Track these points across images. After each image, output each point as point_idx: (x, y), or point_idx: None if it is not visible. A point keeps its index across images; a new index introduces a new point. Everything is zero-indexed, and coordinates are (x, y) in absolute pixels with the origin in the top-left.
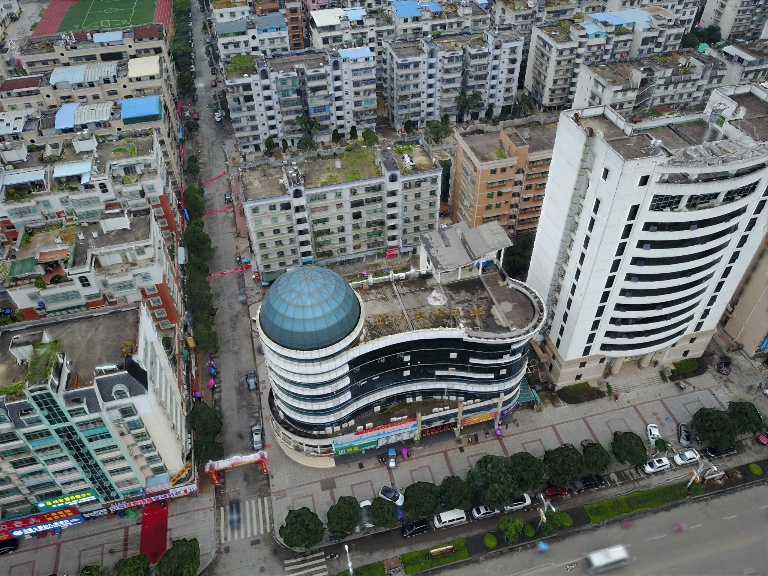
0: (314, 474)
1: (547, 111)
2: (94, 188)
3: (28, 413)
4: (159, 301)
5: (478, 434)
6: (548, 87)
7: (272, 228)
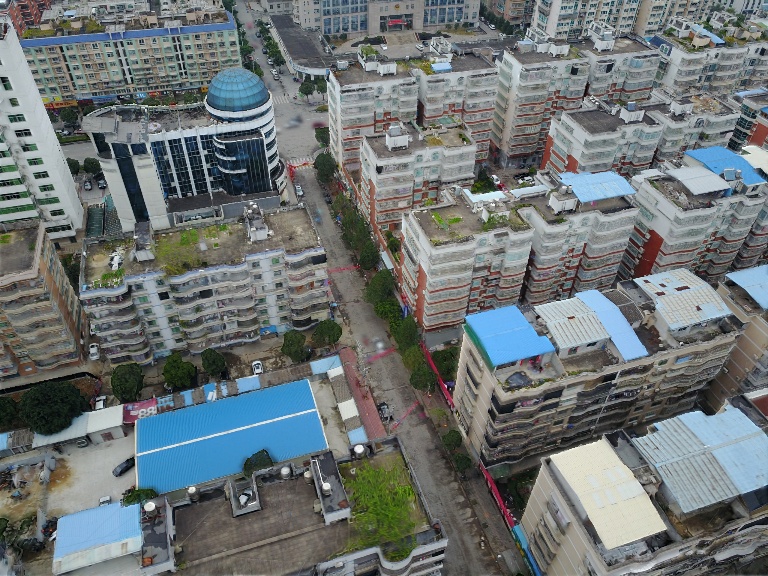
0: None
1: None
2: None
3: None
4: None
5: None
6: None
7: None
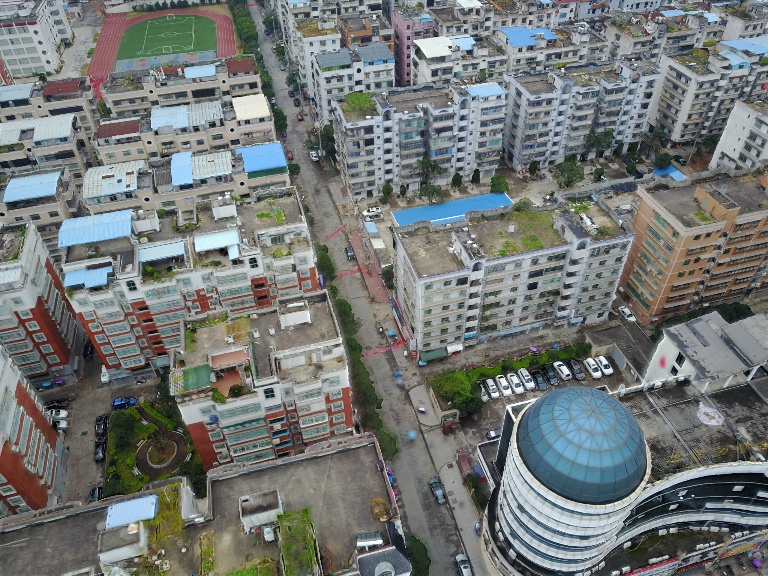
0: None
1: (675, 147)
2: (243, 263)
3: None
4: (341, 406)
5: (732, 566)
6: (681, 122)
7: (442, 305)
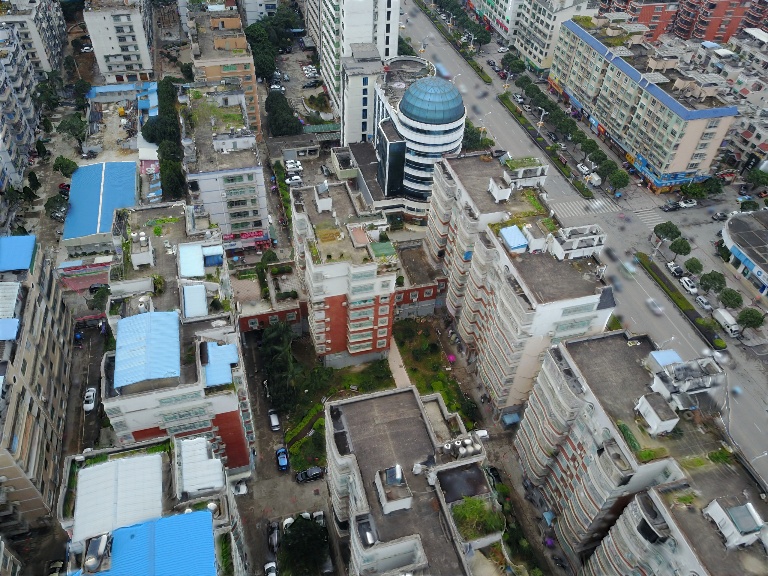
0: None
1: None
2: None
3: None
4: None
5: None
6: (45, 60)
7: None
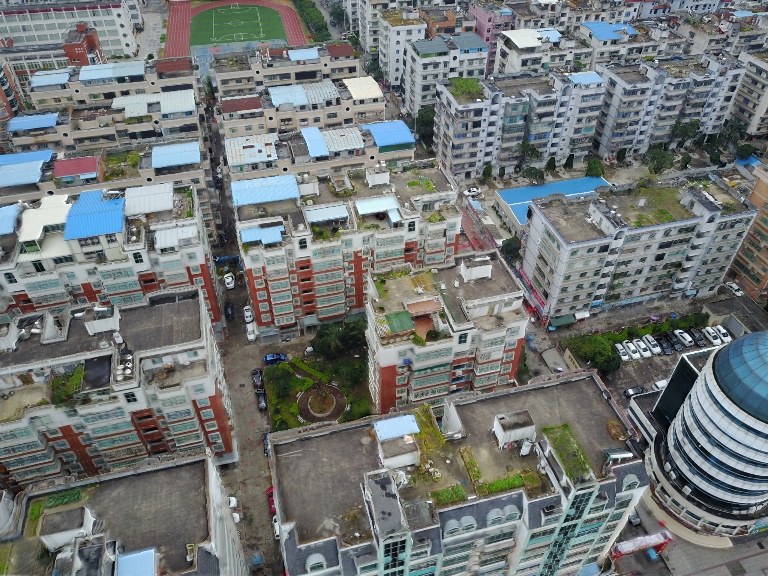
0: (714, 556)
1: (749, 140)
2: (403, 226)
3: (552, 512)
4: (511, 356)
5: None
6: (759, 116)
7: (582, 271)
